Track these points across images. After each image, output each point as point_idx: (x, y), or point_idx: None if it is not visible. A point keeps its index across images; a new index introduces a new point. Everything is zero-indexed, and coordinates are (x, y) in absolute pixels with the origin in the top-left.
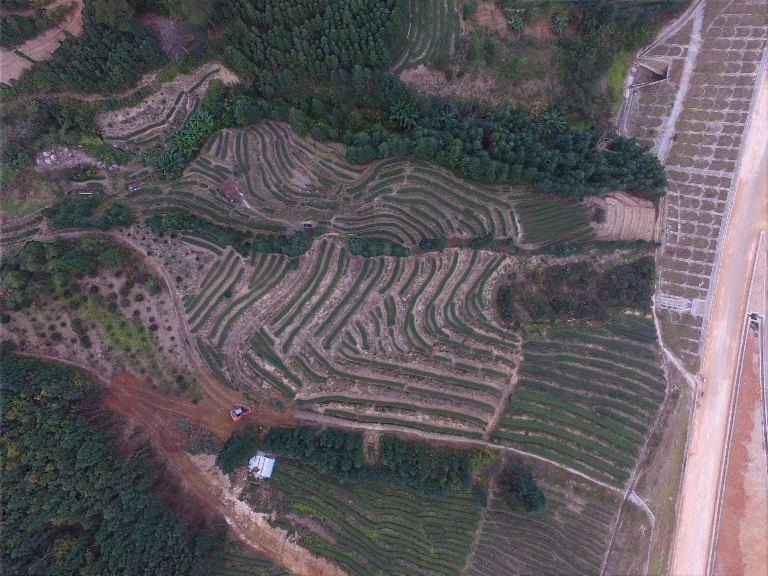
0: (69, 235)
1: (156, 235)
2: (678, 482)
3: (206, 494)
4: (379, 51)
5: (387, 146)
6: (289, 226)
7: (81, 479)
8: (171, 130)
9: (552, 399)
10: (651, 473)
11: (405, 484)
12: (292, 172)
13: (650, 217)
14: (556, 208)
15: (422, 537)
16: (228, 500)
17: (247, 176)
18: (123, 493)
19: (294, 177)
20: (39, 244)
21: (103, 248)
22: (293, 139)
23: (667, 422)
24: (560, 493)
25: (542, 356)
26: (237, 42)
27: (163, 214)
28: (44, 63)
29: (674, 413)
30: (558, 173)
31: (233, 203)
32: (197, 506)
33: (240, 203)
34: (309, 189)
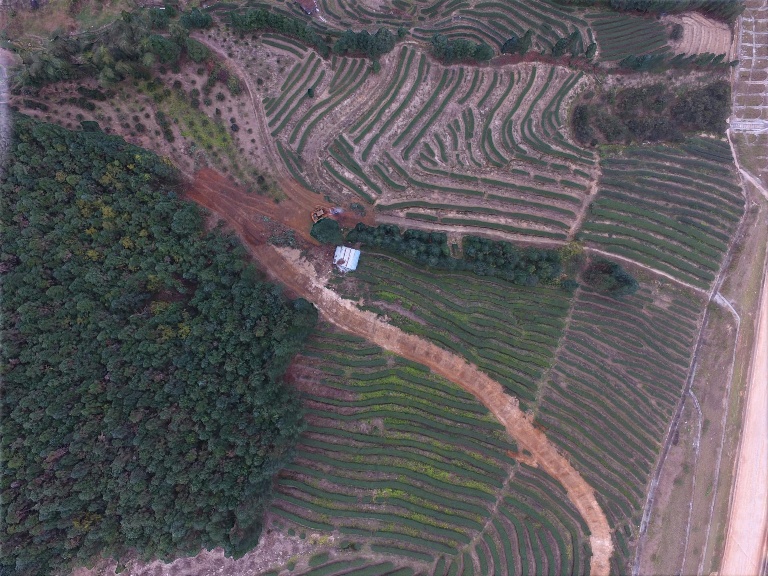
0: None
1: (237, 37)
2: (757, 298)
3: (292, 283)
4: None
5: None
6: None
7: (175, 245)
8: None
9: (633, 207)
10: (735, 277)
11: None
12: None
13: (726, 39)
14: (633, 25)
15: (513, 320)
16: (315, 287)
17: None
18: (220, 255)
19: None
20: None
21: None
22: None
23: (748, 233)
24: (647, 289)
25: (620, 171)
26: None
27: None
28: None
29: (754, 225)
30: None
31: (310, 16)
32: (285, 290)
33: (316, 18)
34: (383, 11)
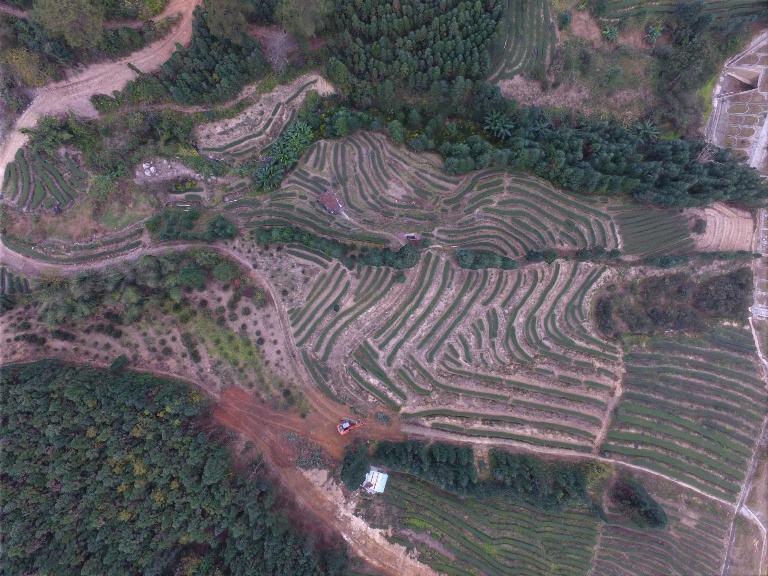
0: (173, 248)
1: (261, 248)
2: None
3: (321, 510)
4: (482, 62)
5: (489, 157)
6: (392, 238)
7: (206, 496)
8: (267, 141)
9: (658, 412)
10: (760, 486)
11: (522, 499)
12: (388, 183)
13: (748, 228)
14: (656, 219)
15: (542, 553)
16: (344, 516)
17: (345, 187)
18: (251, 511)
19: (390, 188)
20: (155, 258)
21: (214, 262)
22: (388, 150)
23: None
24: (674, 507)
25: (644, 368)
26: (337, 53)
27: (266, 226)
28: (150, 75)
29: None
30: (658, 184)
31: (333, 215)
32: (314, 522)
33: (339, 215)
34: (405, 200)
